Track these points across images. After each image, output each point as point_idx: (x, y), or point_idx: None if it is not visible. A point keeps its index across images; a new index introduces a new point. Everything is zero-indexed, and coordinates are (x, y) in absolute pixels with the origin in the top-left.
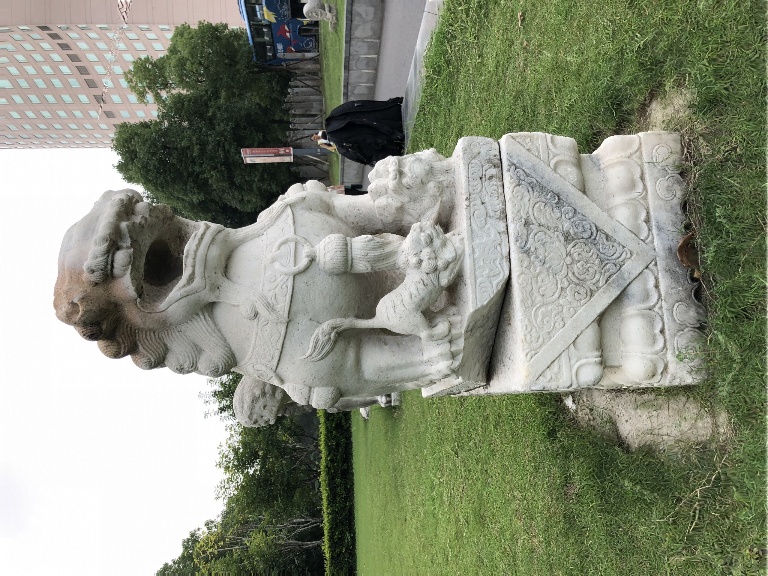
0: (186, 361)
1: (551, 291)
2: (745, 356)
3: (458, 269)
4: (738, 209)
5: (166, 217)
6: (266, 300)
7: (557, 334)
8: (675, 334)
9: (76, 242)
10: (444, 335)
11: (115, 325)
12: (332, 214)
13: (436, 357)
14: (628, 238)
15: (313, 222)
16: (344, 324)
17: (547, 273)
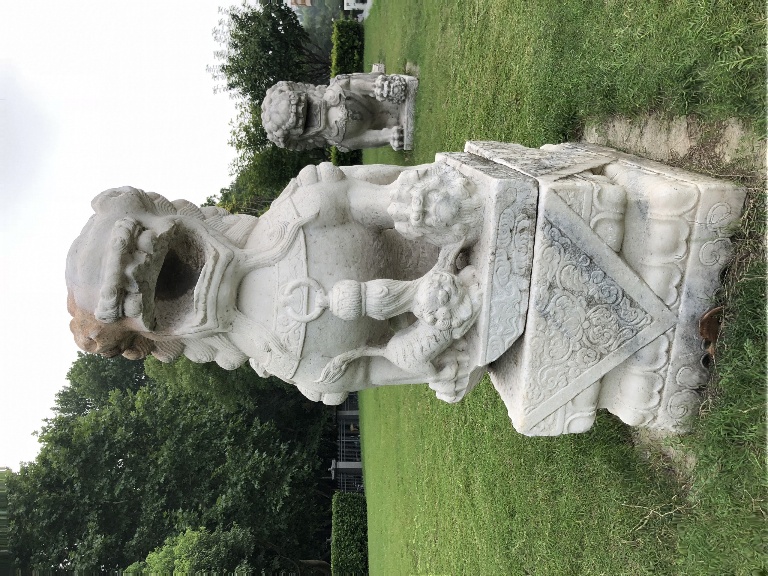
0: (203, 358)
1: (561, 353)
2: (722, 476)
3: (472, 324)
4: (767, 349)
5: (171, 240)
6: (279, 341)
7: (558, 392)
8: (672, 394)
9: (82, 283)
10: (450, 379)
11: (132, 338)
12: (348, 219)
13: (440, 392)
14: (653, 305)
15: (327, 254)
16: (355, 356)
17: (561, 336)
